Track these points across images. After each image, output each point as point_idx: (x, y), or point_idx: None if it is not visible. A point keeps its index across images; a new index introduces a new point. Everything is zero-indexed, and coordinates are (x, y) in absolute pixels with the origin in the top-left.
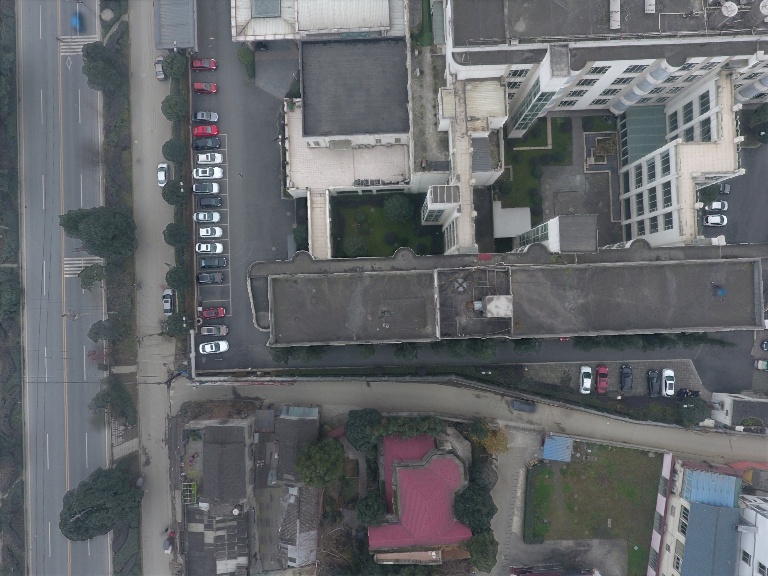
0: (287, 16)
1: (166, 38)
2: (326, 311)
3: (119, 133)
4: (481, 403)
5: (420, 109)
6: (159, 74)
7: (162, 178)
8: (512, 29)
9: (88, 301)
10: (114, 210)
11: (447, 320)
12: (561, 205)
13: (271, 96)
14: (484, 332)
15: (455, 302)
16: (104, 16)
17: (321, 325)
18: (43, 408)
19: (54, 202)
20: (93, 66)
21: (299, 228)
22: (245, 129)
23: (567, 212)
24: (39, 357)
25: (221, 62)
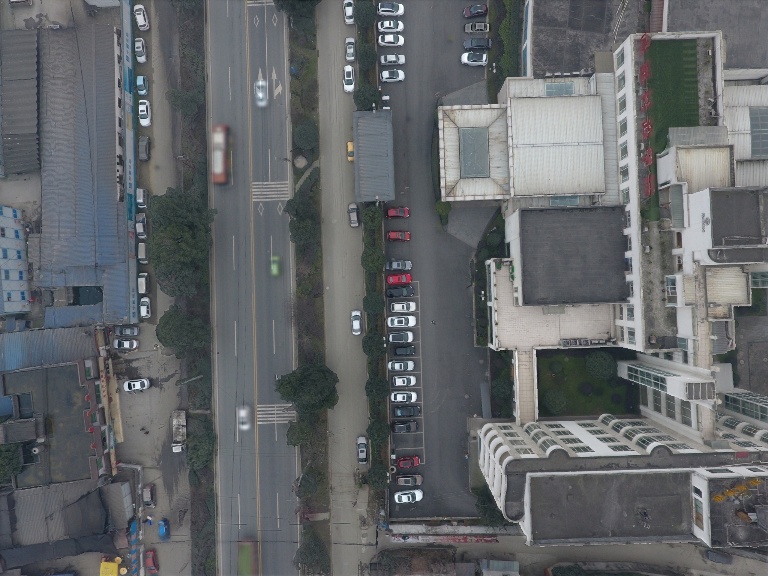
0: (496, 176)
1: (365, 190)
2: (582, 507)
3: (312, 280)
4: (675, 553)
5: (647, 284)
6: (353, 222)
7: (357, 327)
8: (767, 226)
9: (281, 448)
10: (320, 367)
11: (716, 527)
12: (755, 355)
13: (463, 243)
14: (753, 540)
15: (724, 509)
16: (298, 164)
17: (577, 521)
18: (236, 555)
19: (247, 349)
20: (303, 226)
21: (502, 384)
22: (437, 276)
23: (761, 362)
24: (232, 504)
25: (413, 209)
